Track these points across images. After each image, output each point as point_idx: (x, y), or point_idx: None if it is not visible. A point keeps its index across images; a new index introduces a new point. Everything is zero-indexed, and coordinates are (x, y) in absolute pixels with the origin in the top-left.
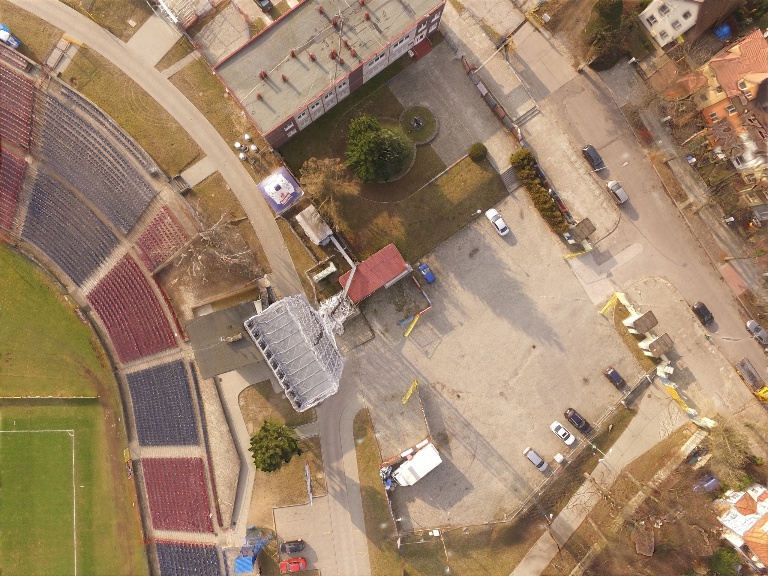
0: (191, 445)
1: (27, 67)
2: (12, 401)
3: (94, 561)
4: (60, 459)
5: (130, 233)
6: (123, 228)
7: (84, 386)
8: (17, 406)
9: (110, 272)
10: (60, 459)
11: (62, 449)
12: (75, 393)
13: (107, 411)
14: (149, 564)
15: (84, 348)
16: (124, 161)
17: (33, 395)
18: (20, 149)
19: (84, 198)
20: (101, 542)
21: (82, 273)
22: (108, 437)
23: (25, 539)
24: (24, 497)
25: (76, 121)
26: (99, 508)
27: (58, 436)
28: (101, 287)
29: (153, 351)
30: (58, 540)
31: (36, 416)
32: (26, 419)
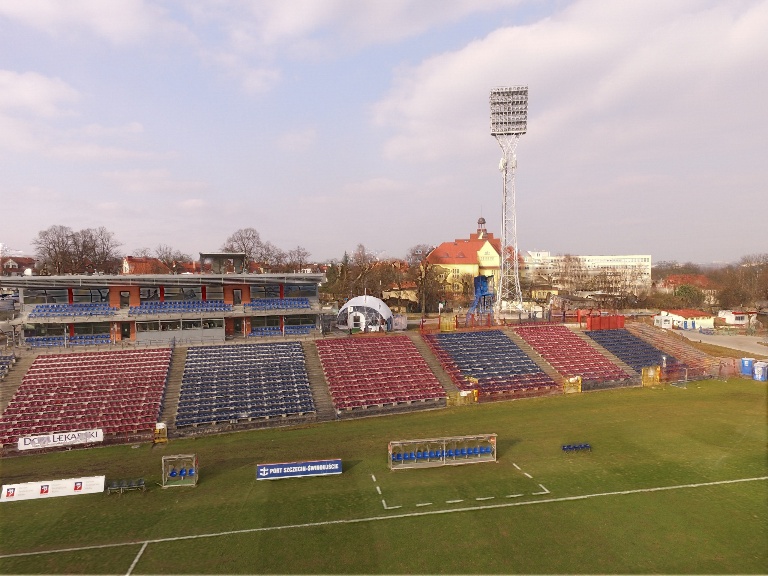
0: None
1: None
2: None
3: None
4: None
5: None
6: None
7: None
8: None
9: None
10: None
11: None
12: None
13: None
14: None
15: None
16: None
17: None
18: None
19: None
20: None
21: None
22: None
23: None
24: None
25: None
26: None
27: None
28: None
29: None
30: None
31: None
32: None
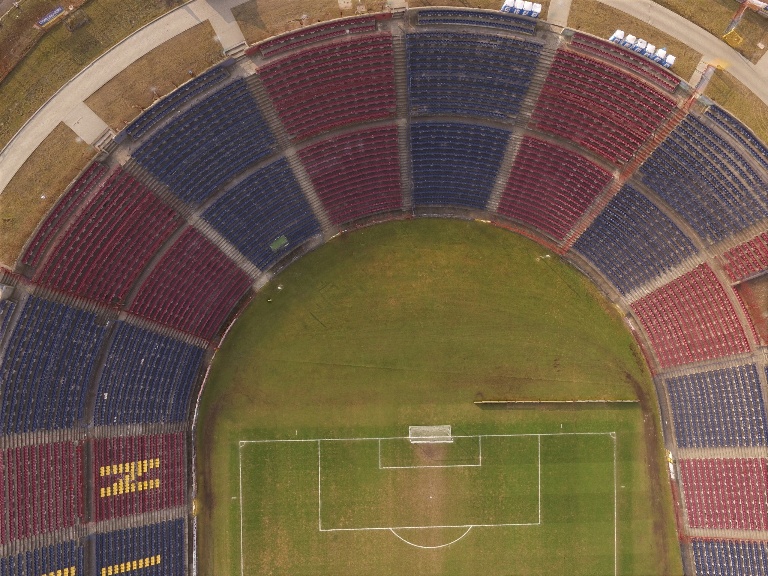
0: (755, 446)
1: (674, 89)
2: (559, 405)
3: (633, 558)
4: (603, 460)
5: (716, 244)
6: (710, 239)
7: (625, 390)
8: (564, 410)
9: (673, 281)
10: (603, 460)
11: (605, 451)
12: (617, 397)
13: (646, 414)
14: (681, 561)
15: (625, 354)
16: (757, 176)
17: (579, 399)
18: (609, 165)
19: (666, 211)
20: (639, 540)
21: (635, 282)
22: (646, 439)
23: (570, 538)
24: (569, 497)
25: (710, 139)
26: (637, 507)
27: (601, 438)
28: (655, 295)
29: (712, 356)
30: (600, 538)
31: (581, 419)
32: (572, 422)
